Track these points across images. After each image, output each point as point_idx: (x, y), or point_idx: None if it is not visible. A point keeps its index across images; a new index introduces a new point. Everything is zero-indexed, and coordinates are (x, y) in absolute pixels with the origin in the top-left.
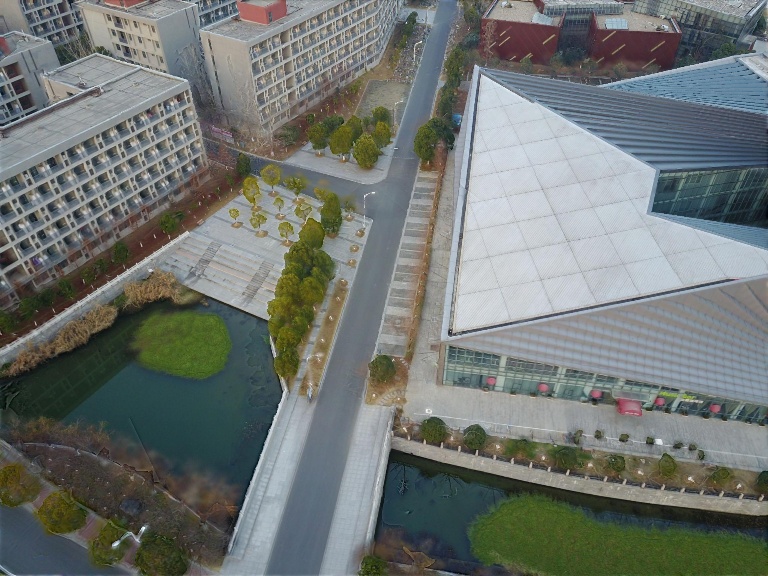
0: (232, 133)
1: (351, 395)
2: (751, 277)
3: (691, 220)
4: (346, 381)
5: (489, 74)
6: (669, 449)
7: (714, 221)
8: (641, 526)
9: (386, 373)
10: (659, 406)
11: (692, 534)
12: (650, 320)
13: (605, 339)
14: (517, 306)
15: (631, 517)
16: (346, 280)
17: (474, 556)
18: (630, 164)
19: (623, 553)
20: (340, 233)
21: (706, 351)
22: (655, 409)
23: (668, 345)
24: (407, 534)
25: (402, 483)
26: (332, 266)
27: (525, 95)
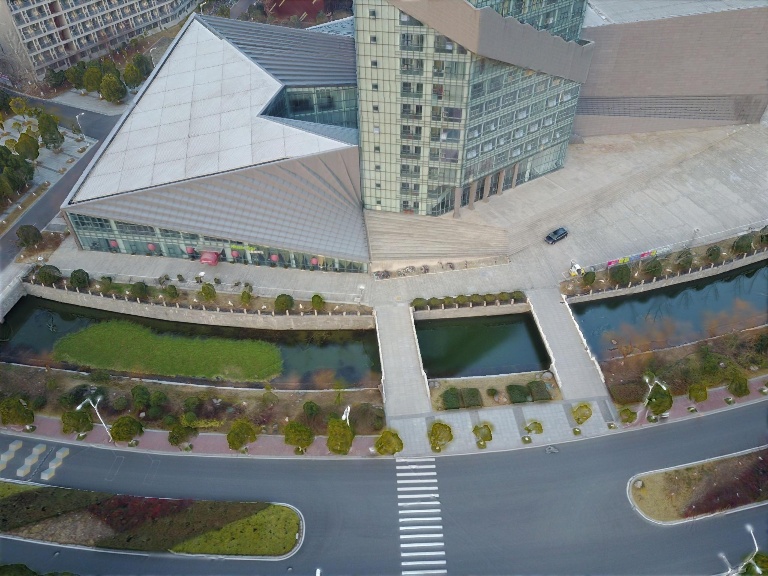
0: (8, 77)
1: (6, 257)
2: (302, 156)
3: (293, 121)
4: (8, 248)
5: (200, 19)
6: (230, 287)
7: (317, 123)
8: (188, 338)
9: (27, 237)
10: (238, 259)
11: (223, 342)
12: (227, 191)
13: (189, 205)
14: (127, 183)
15: (185, 333)
16: (50, 183)
17: (50, 357)
18: (266, 81)
19: (162, 353)
20: (65, 150)
21: (270, 214)
22: (237, 262)
23: (240, 210)
24: (8, 345)
25: (50, 327)
26: (27, 168)
27: (219, 34)
